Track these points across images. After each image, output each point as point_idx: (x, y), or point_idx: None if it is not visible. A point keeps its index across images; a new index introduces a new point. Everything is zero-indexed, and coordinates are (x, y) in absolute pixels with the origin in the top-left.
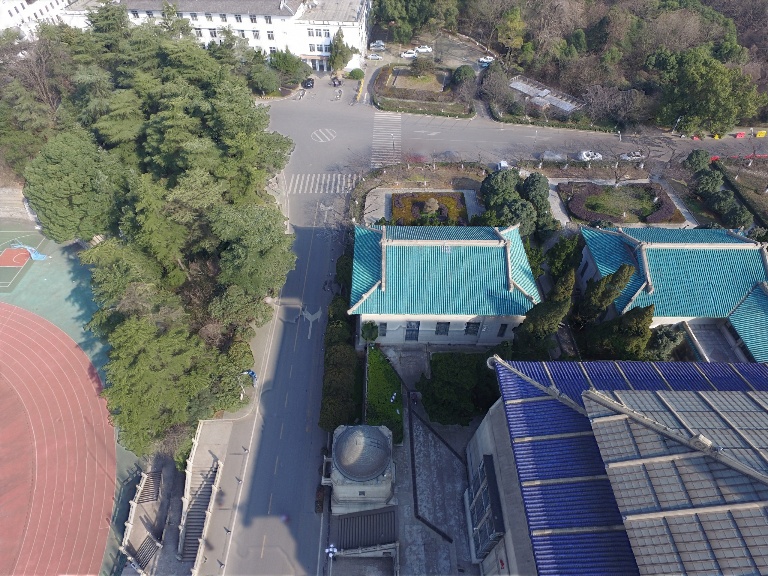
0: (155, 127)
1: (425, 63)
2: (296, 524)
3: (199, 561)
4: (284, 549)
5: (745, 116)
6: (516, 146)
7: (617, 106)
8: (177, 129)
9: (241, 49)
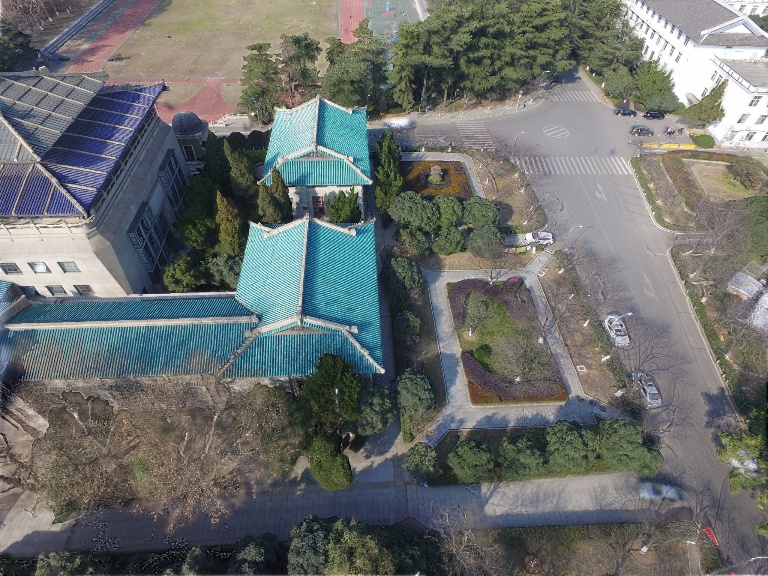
0: None
1: (746, 166)
2: None
3: None
4: None
5: None
6: (610, 261)
7: (752, 346)
8: None
9: (628, 47)
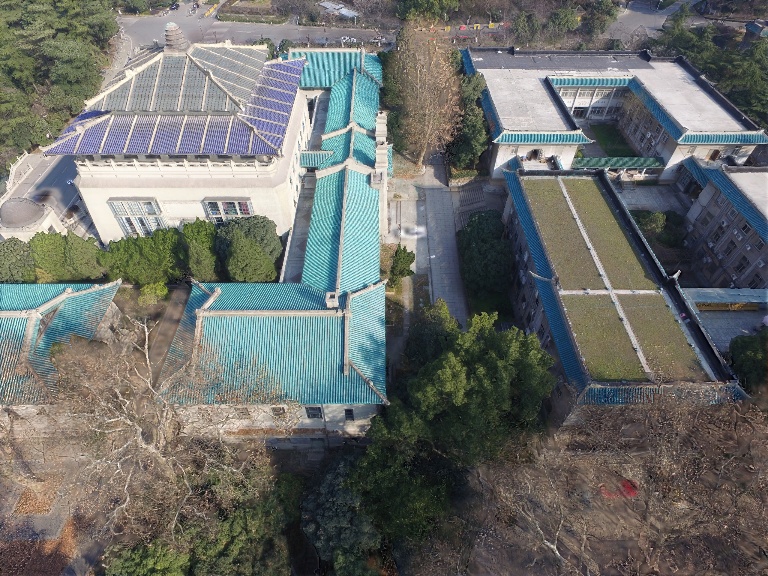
0: (26, 8)
1: None
2: (66, 189)
3: (6, 199)
4: (55, 197)
5: (447, 8)
6: (302, 37)
7: (372, 7)
8: (35, 4)
9: None
